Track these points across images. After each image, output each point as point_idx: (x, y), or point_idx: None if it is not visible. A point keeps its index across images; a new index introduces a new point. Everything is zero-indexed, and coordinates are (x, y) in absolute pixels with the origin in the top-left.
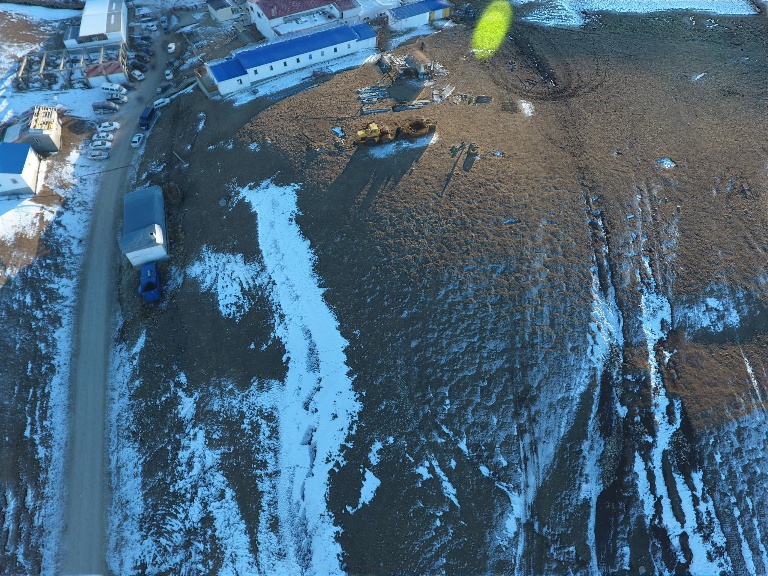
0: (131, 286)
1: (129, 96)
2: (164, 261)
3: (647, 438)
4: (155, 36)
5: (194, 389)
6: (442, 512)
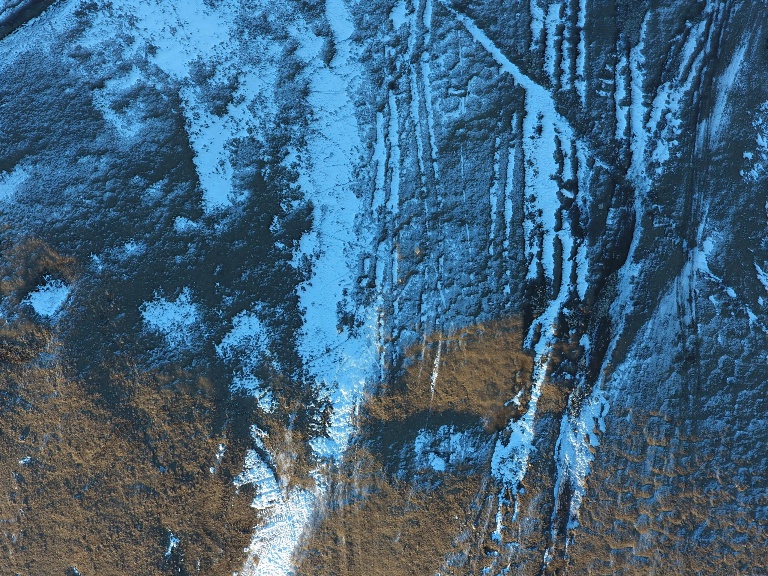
0: None
1: None
2: None
3: (568, 312)
4: None
5: None
6: None
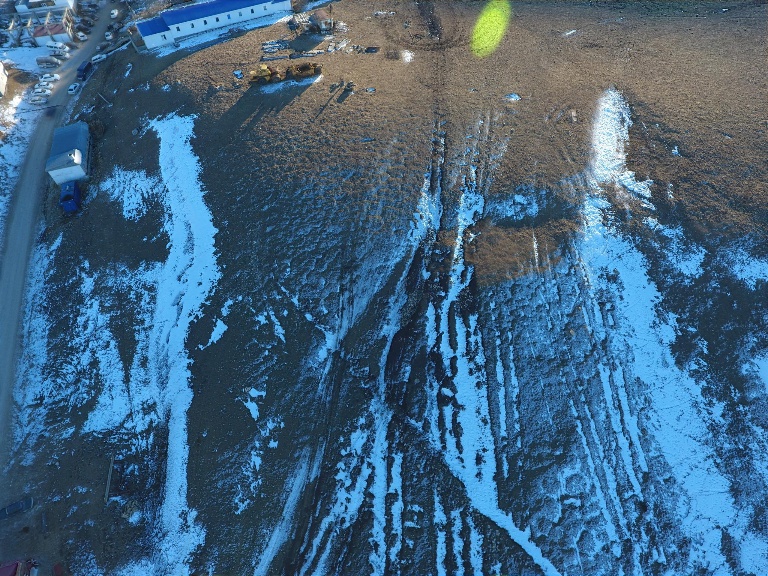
0: (55, 201)
1: (72, 54)
2: (84, 181)
3: (441, 293)
4: (101, 4)
5: (94, 271)
6: (271, 346)
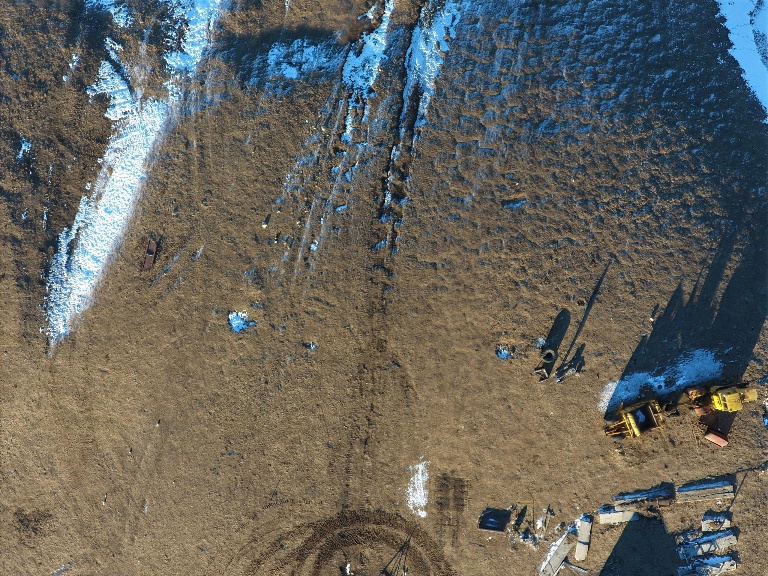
0: None
1: None
2: None
3: None
4: None
5: None
6: None
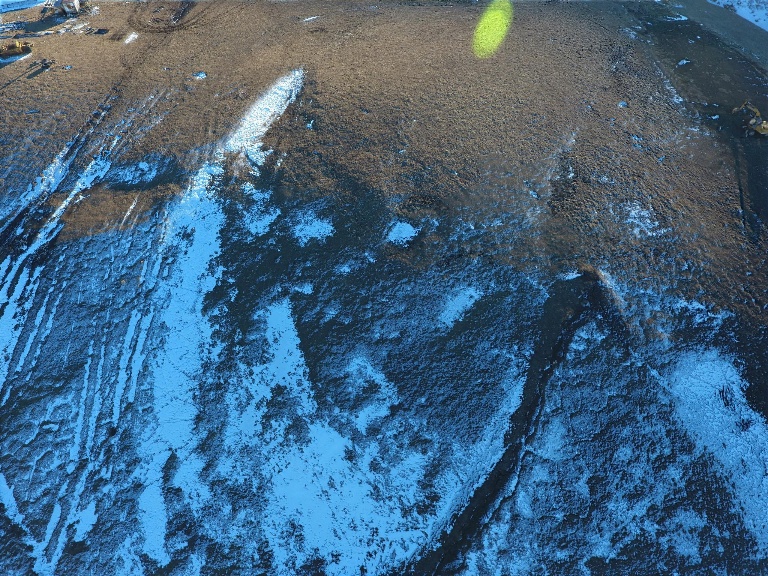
0: None
1: None
2: None
3: (24, 247)
4: None
5: None
6: None
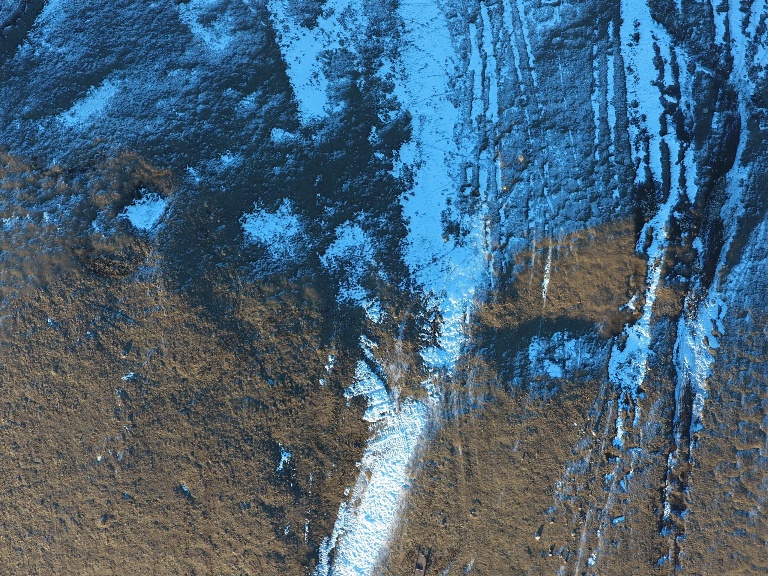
0: None
1: None
2: None
3: (679, 215)
4: None
5: None
6: None
